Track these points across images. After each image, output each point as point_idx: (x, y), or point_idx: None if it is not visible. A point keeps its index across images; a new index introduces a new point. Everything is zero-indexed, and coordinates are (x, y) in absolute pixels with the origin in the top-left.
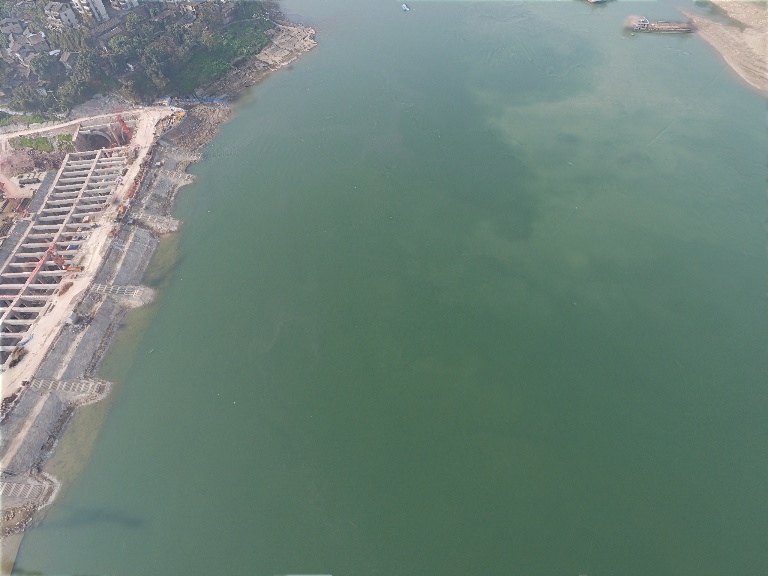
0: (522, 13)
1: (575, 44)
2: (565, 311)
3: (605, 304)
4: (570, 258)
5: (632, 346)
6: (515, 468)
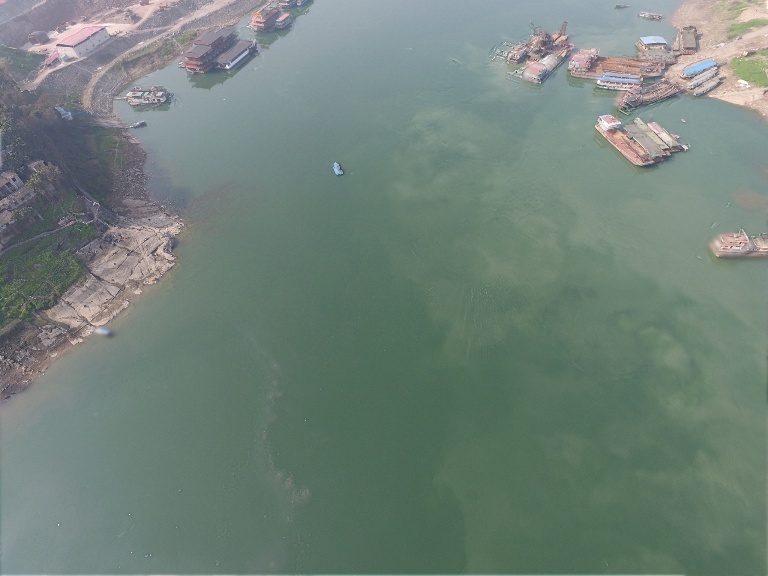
0: (524, 193)
1: (622, 291)
2: None
3: None
4: None
5: None
6: None
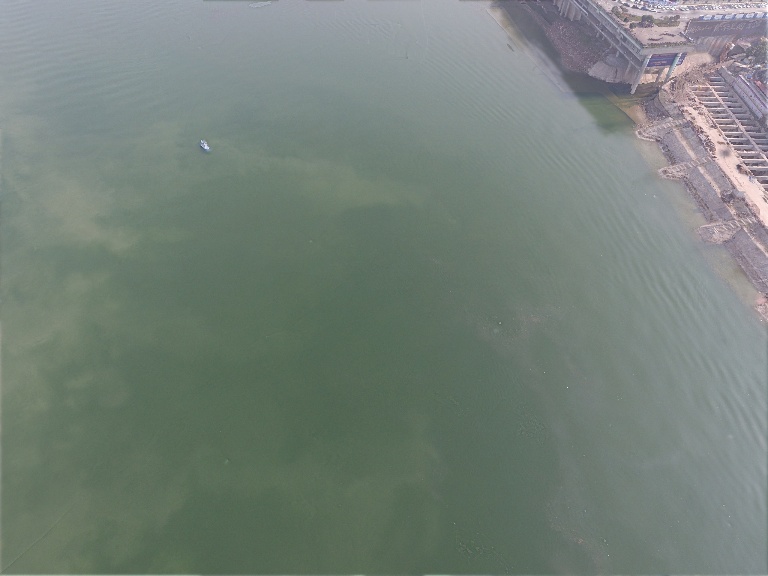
0: None
1: None
2: (322, 235)
3: (284, 243)
4: (301, 273)
5: (280, 210)
6: (383, 147)
